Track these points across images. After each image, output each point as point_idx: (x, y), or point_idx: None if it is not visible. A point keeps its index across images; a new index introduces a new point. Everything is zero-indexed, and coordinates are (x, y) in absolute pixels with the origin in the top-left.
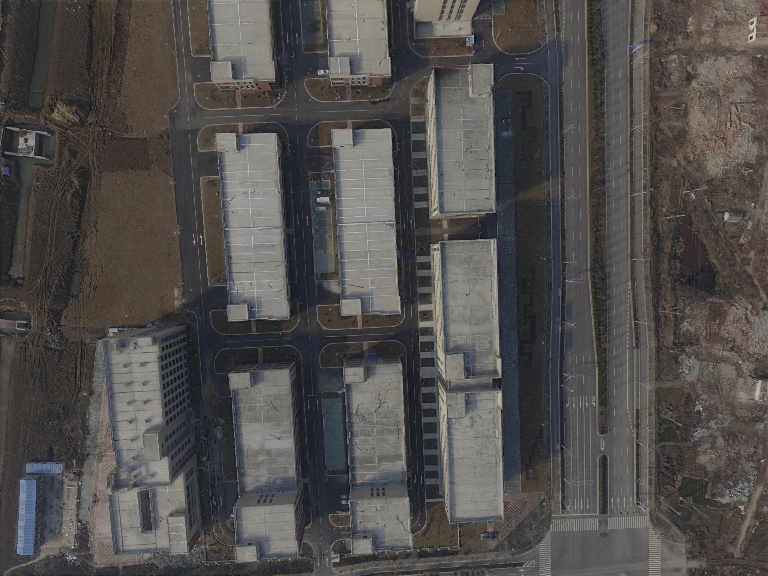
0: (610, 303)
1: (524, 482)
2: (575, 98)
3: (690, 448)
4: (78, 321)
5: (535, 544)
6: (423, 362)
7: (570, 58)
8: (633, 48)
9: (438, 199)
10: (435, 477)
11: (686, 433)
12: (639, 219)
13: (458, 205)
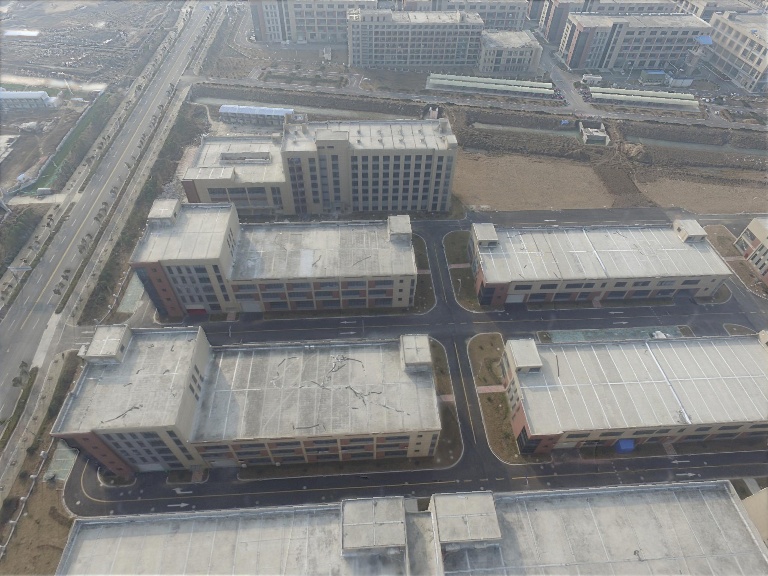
0: None
1: None
2: None
3: None
4: None
5: None
6: (427, 503)
7: None
8: None
9: None
10: None
11: None
12: None
13: None
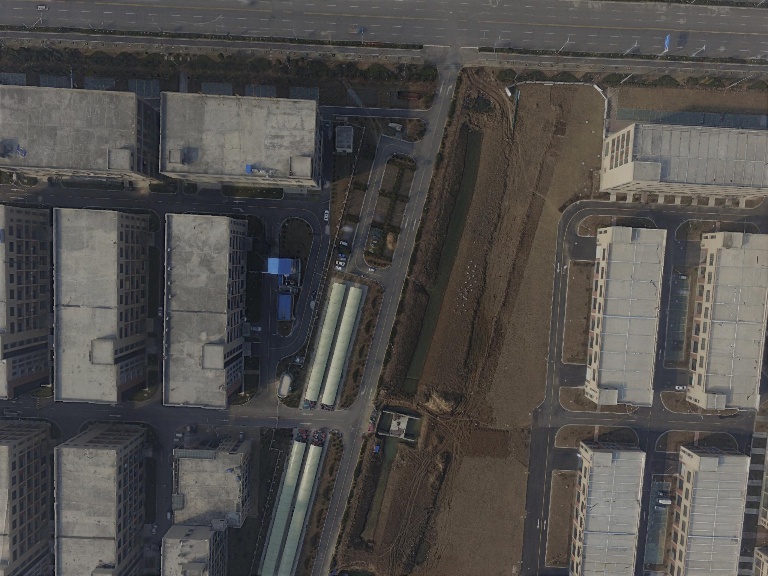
0: None
1: None
2: None
3: None
4: None
5: None
6: None
7: None
8: None
9: None
10: None
11: None
12: None
13: None
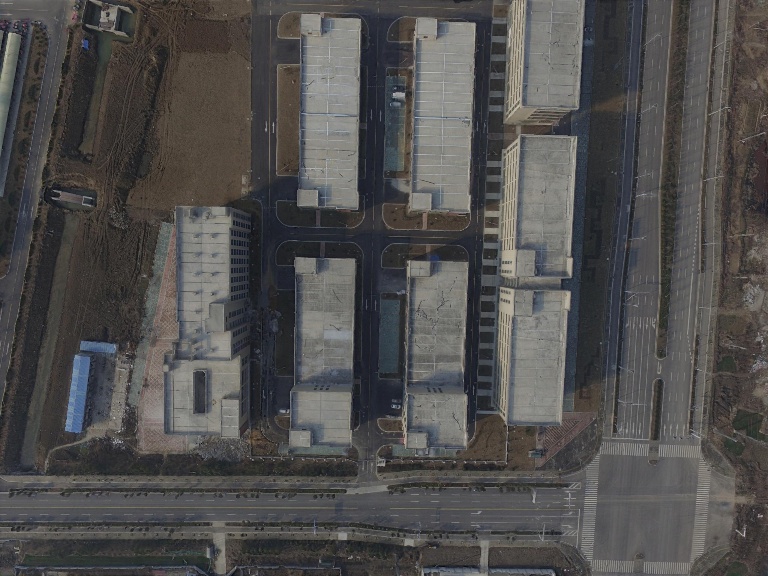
0: (678, 224)
1: (577, 401)
2: (659, 11)
3: (748, 380)
4: (144, 202)
5: (583, 466)
6: (485, 269)
7: None
8: None
9: (522, 91)
10: (488, 388)
11: (745, 364)
12: (714, 140)
13: (541, 99)
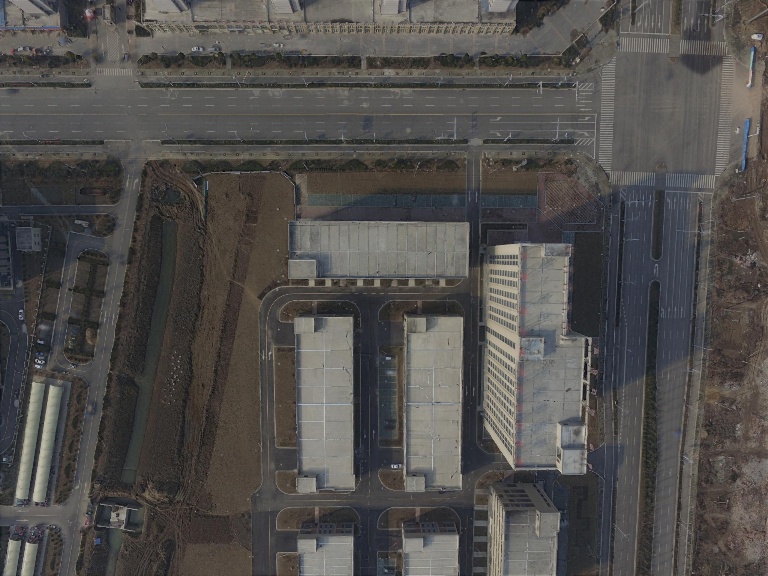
0: None
1: None
2: (628, 492)
3: None
4: None
5: None
6: None
7: (625, 458)
8: (684, 450)
9: None
10: None
11: None
12: None
13: None
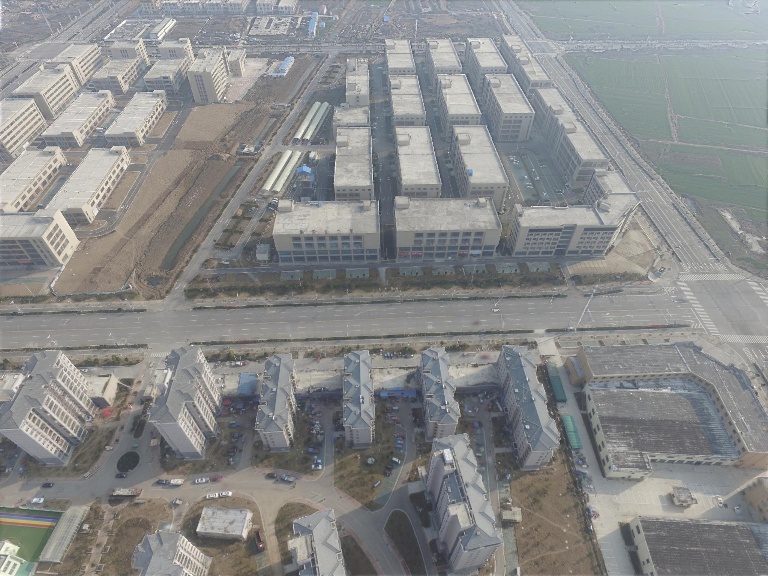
0: None
1: None
2: None
3: None
4: None
5: None
6: None
7: None
8: None
9: None
10: None
11: None
12: None
13: None
